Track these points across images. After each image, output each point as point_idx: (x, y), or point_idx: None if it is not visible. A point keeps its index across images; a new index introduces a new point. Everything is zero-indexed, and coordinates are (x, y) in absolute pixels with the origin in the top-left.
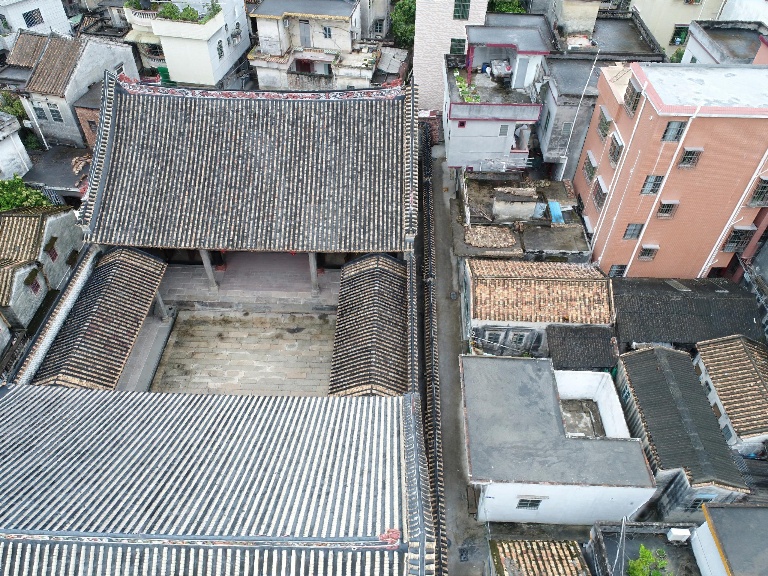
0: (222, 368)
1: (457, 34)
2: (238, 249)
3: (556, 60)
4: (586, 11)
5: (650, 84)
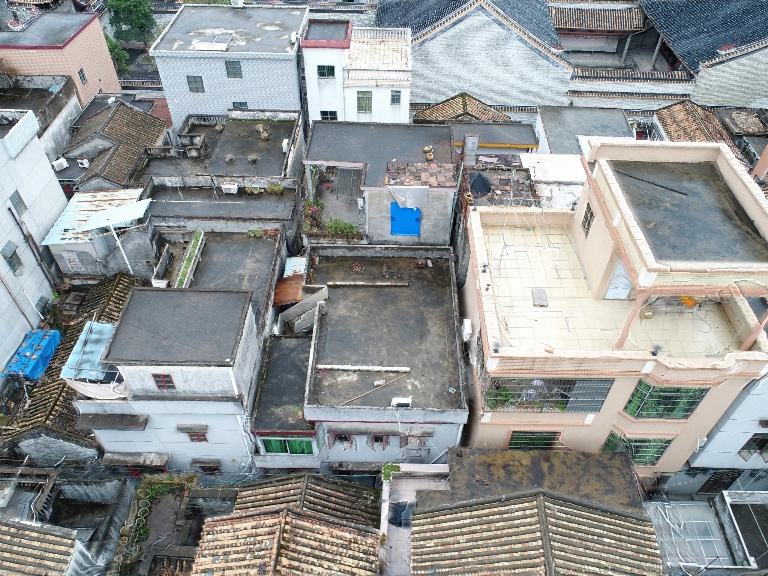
0: None
1: None
2: None
3: None
4: None
5: None
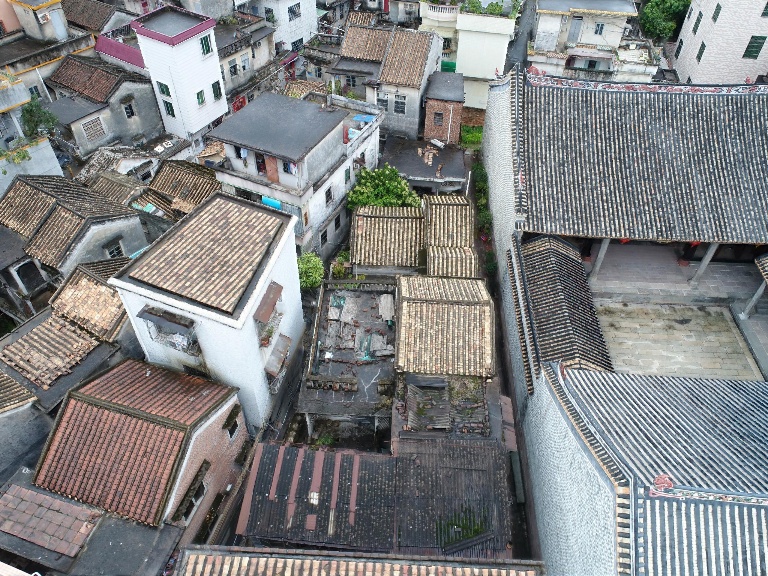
0: (634, 357)
1: (760, 31)
2: (669, 239)
3: None
4: None
5: None
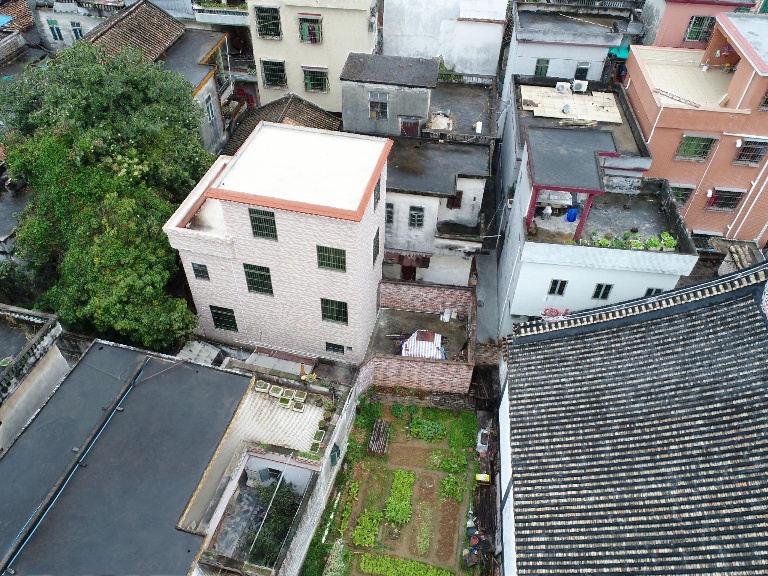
0: None
1: (375, 228)
2: None
3: None
4: None
5: None
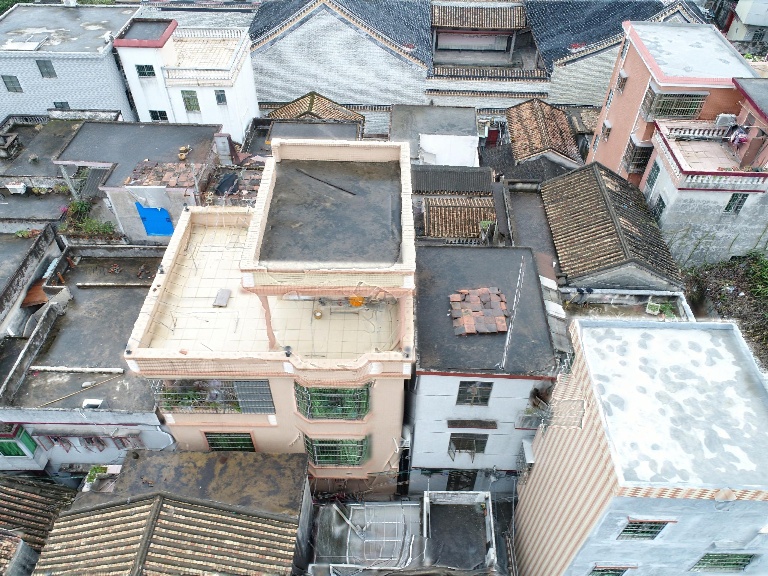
0: None
1: None
2: (531, 28)
3: None
4: None
5: None
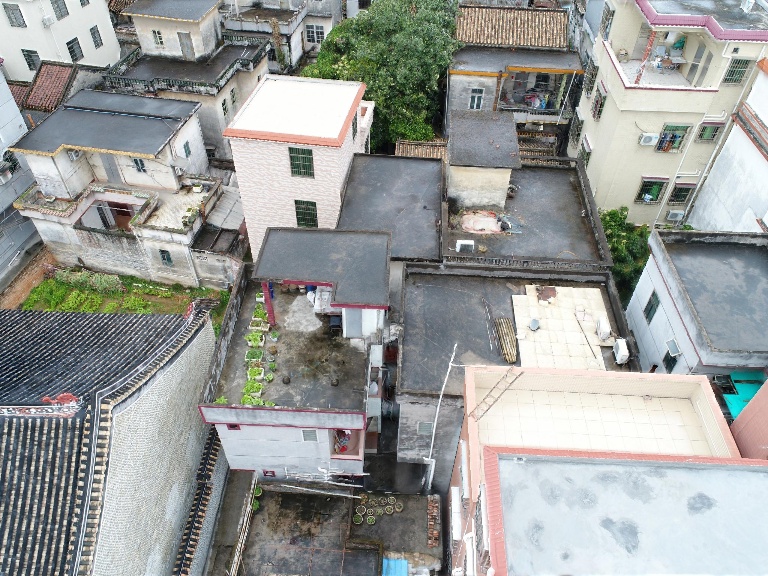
0: None
1: (302, 195)
2: None
3: (427, 277)
4: (490, 179)
5: (503, 565)
